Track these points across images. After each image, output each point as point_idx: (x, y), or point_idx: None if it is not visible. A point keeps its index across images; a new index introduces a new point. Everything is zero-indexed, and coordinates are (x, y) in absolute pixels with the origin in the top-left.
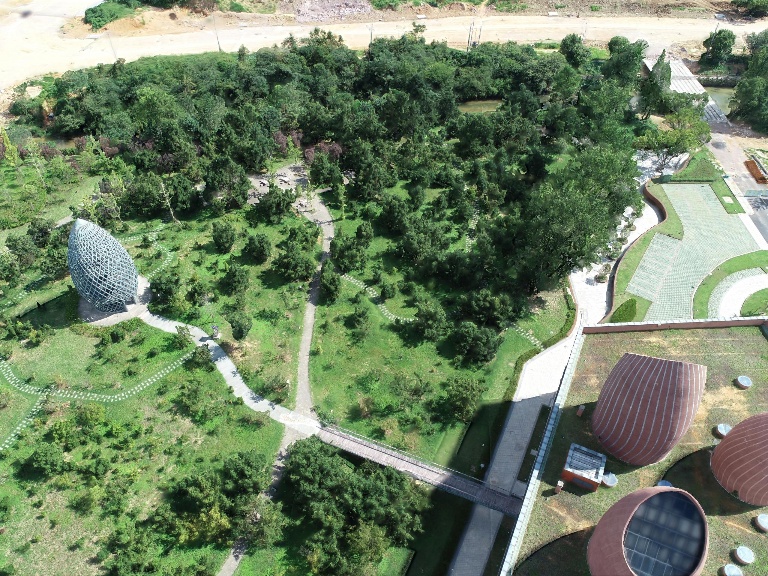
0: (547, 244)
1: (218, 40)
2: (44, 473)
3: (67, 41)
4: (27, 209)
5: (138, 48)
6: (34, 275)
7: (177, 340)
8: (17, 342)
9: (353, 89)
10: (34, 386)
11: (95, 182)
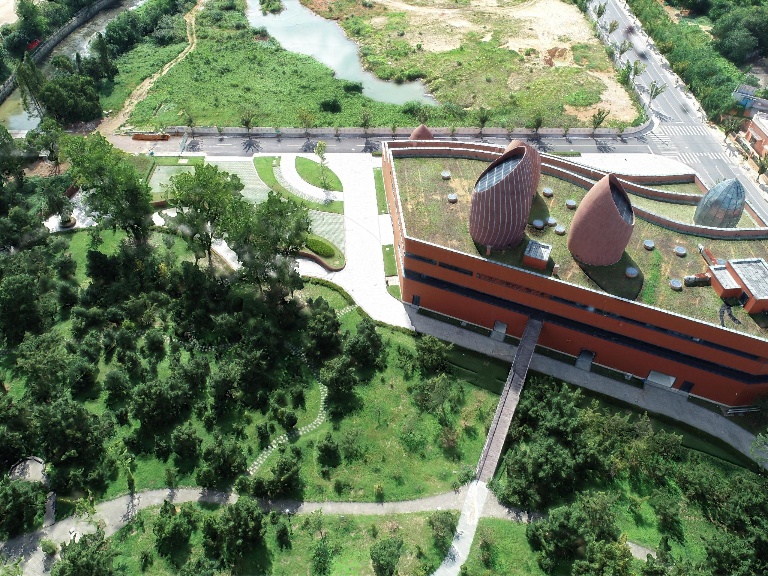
0: None
1: None
2: None
3: None
4: None
5: None
6: None
7: None
8: None
9: None
10: None
11: None
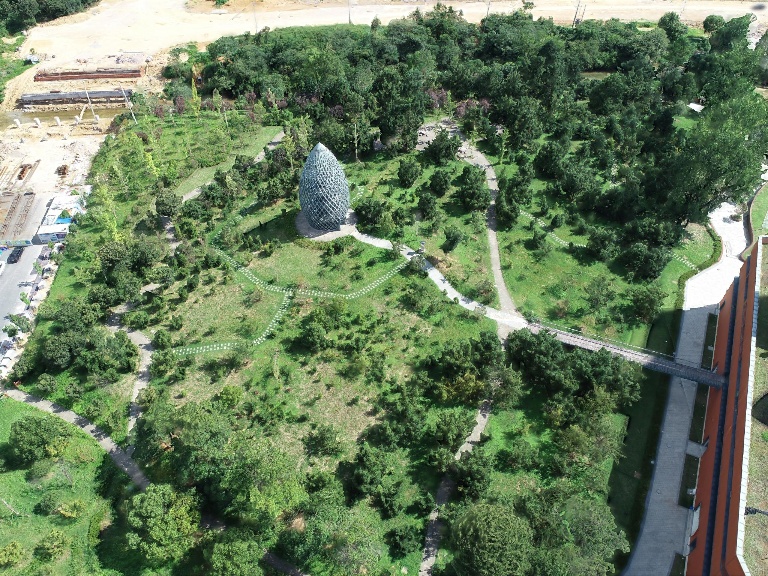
0: (696, 182)
1: (349, 13)
2: (309, 349)
3: (195, 15)
4: (219, 151)
5: (262, 22)
6: (243, 203)
7: (393, 252)
8: (250, 253)
9: (472, 59)
10: (277, 286)
11: (269, 131)
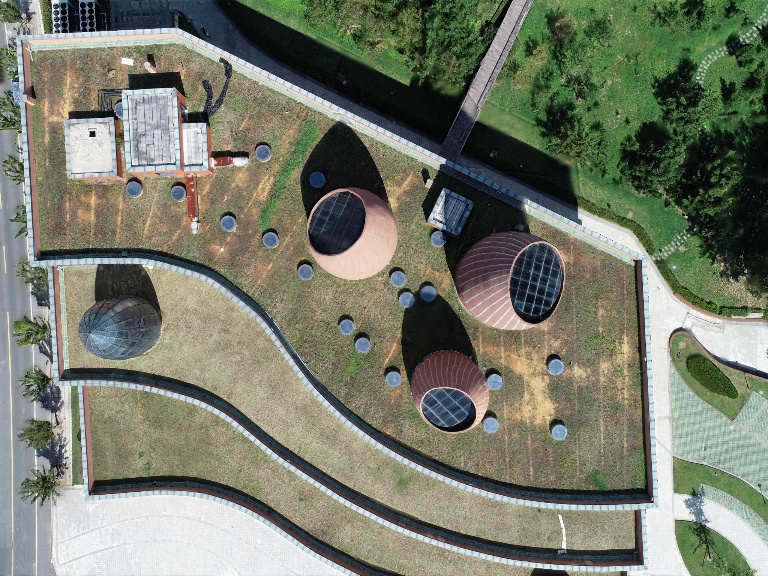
0: None
1: None
2: None
3: None
4: None
5: None
6: None
7: None
8: None
9: None
10: None
11: None
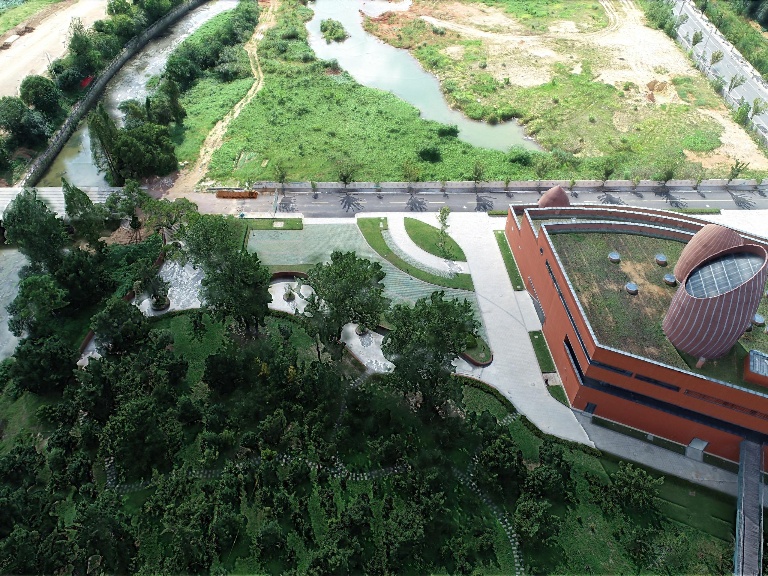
0: None
1: None
2: None
3: None
4: None
5: None
6: None
7: None
8: None
9: None
10: None
11: None
